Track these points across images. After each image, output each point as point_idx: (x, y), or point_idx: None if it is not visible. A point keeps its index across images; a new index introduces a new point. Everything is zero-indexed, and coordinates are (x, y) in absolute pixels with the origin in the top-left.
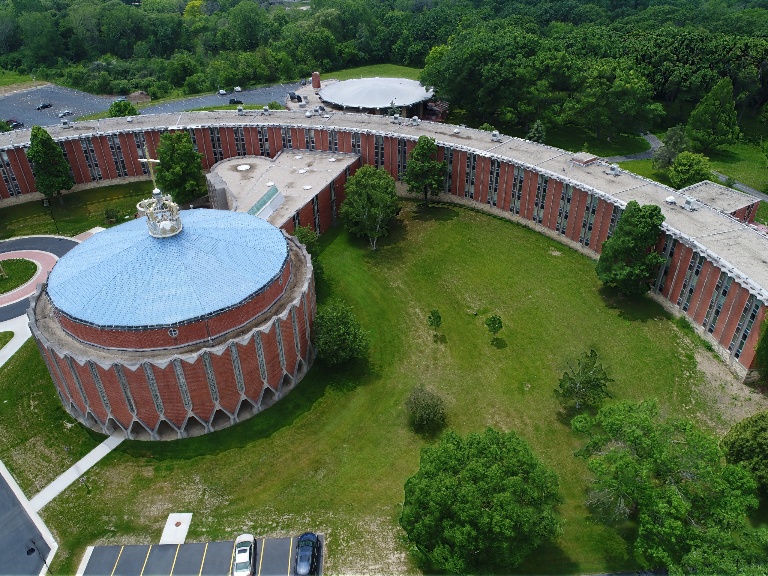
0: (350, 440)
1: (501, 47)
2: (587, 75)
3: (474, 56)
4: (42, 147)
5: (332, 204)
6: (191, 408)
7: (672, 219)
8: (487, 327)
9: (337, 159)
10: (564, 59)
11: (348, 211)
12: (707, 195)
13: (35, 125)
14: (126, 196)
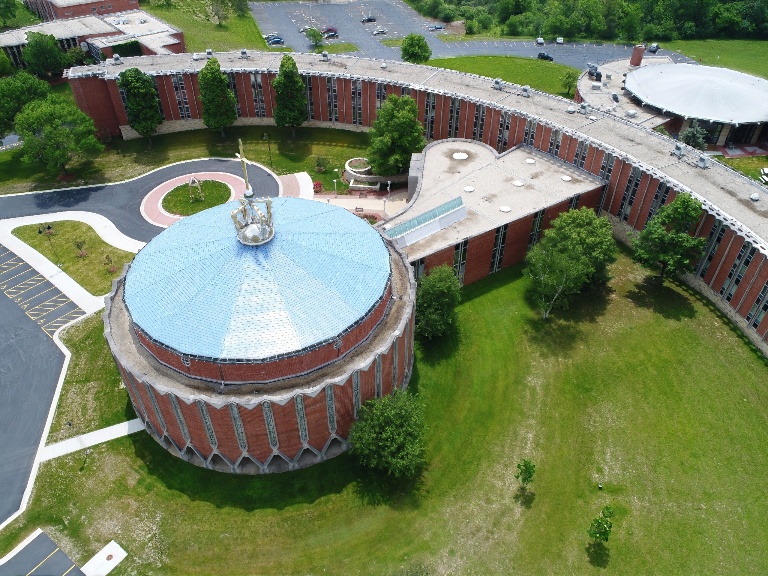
0: (319, 573)
1: None
2: None
3: None
4: (284, 79)
5: (533, 236)
6: (189, 440)
7: None
8: None
9: (574, 179)
10: None
11: None
12: None
13: None
14: (350, 146)
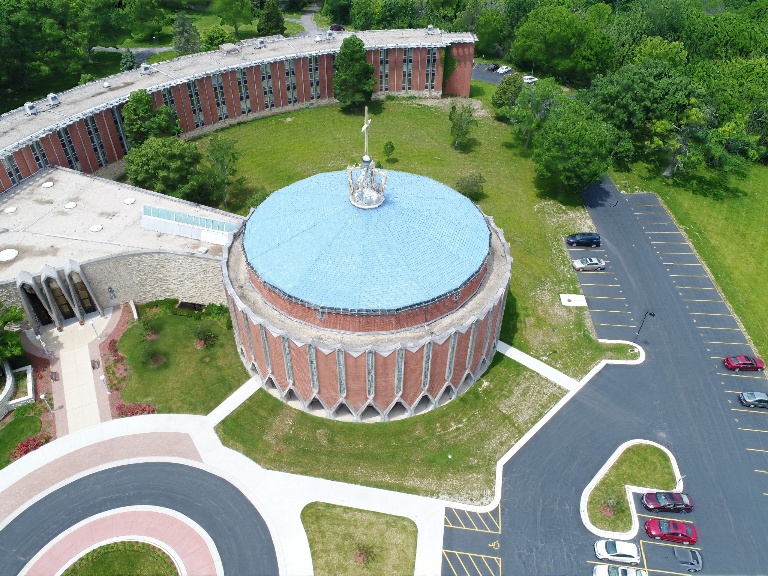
0: None
1: None
2: (66, 1)
3: None
4: None
5: None
6: None
7: None
8: None
9: (46, 182)
10: None
11: (190, 188)
12: None
13: None
14: None
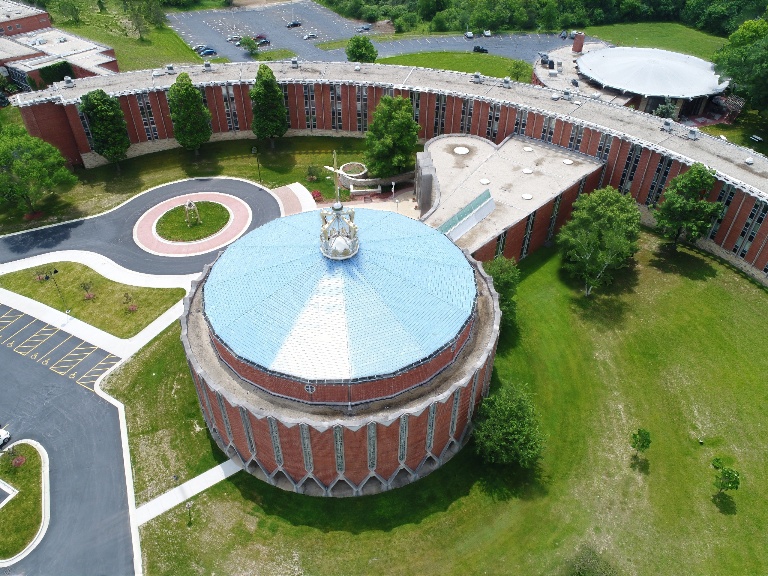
0: None
1: None
2: None
3: None
4: (264, 89)
5: (552, 220)
6: (312, 470)
7: None
8: (713, 470)
9: (574, 161)
10: None
11: (568, 240)
12: None
13: (263, 64)
14: None
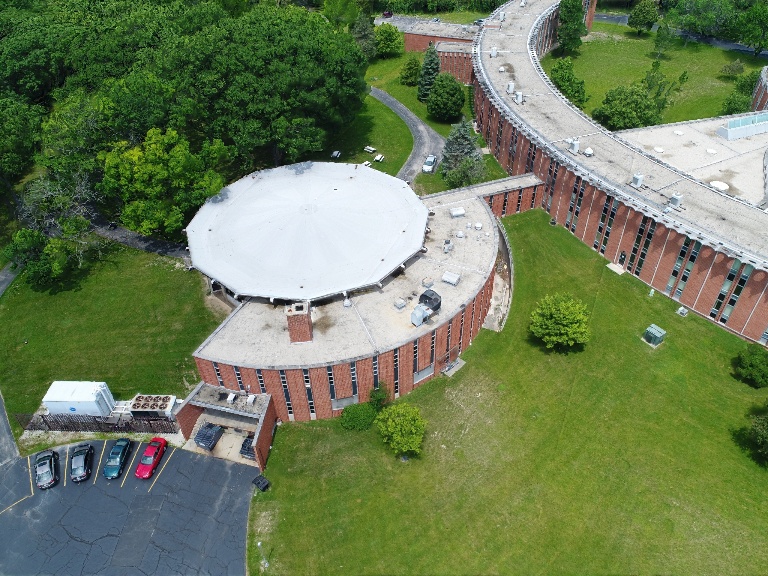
0: None
1: None
2: None
3: None
4: None
5: None
6: None
7: (546, 4)
8: (646, 82)
9: None
10: None
11: None
12: (430, 31)
13: None
14: None
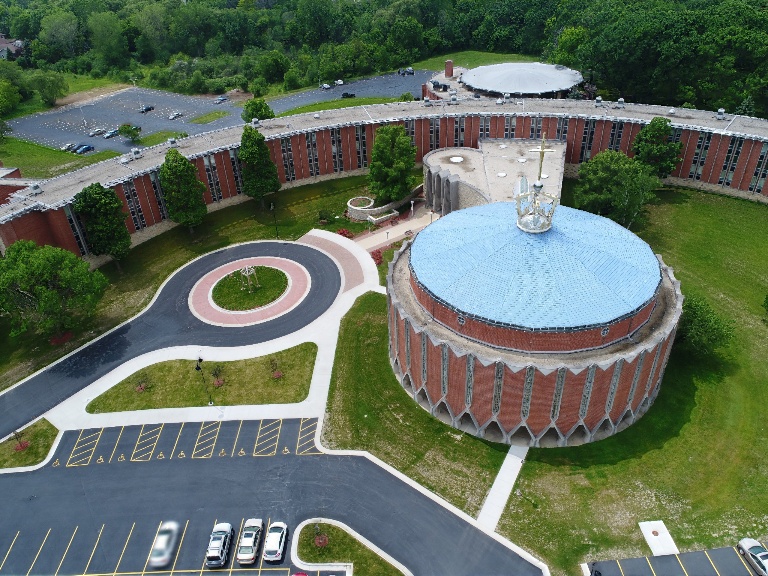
0: (764, 433)
1: (670, 25)
2: None
3: (648, 35)
4: (258, 148)
5: None
6: (610, 410)
7: None
8: None
9: None
10: (741, 34)
11: (597, 198)
12: None
13: (247, 125)
14: (323, 196)
